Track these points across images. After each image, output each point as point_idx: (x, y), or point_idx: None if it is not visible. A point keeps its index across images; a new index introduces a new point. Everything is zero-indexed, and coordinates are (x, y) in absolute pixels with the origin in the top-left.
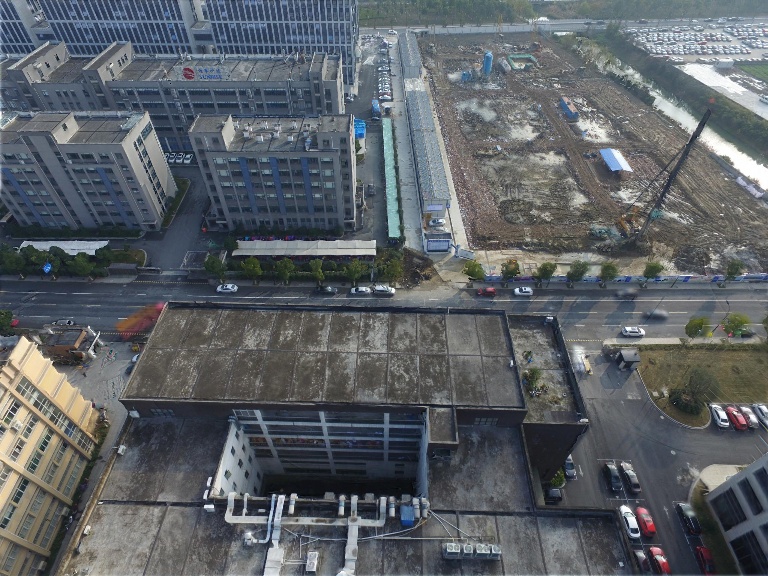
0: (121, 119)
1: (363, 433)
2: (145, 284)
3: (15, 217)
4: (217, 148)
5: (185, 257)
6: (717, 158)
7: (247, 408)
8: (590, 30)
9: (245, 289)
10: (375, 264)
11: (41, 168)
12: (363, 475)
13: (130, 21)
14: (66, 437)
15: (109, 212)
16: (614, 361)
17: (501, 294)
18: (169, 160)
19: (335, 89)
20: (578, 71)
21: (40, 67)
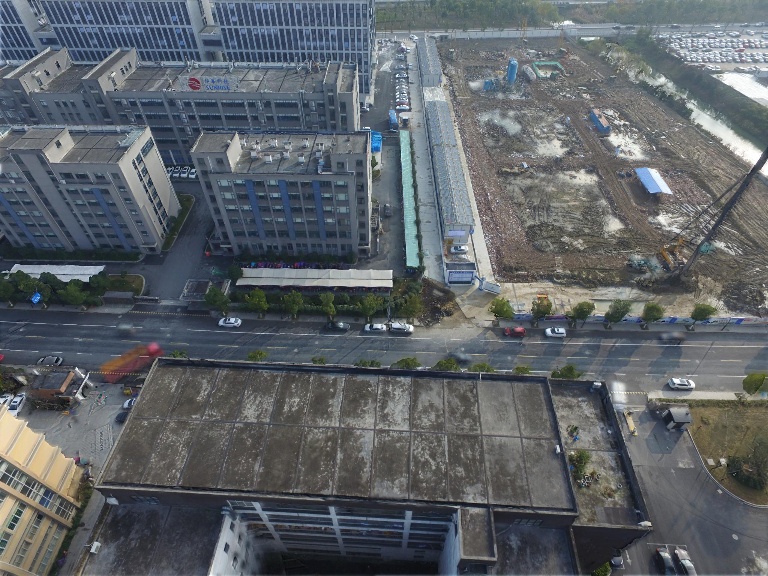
0: (120, 134)
1: (379, 525)
2: (142, 315)
3: (7, 237)
4: (221, 169)
5: (185, 286)
6: (765, 179)
7: (244, 500)
8: (620, 36)
9: (249, 323)
10: (391, 296)
11: (33, 188)
12: (377, 557)
13: (136, 25)
14: (41, 508)
15: (106, 234)
16: (661, 419)
17: (531, 335)
18: (173, 174)
19: (351, 101)
20: (608, 80)
21: (39, 75)
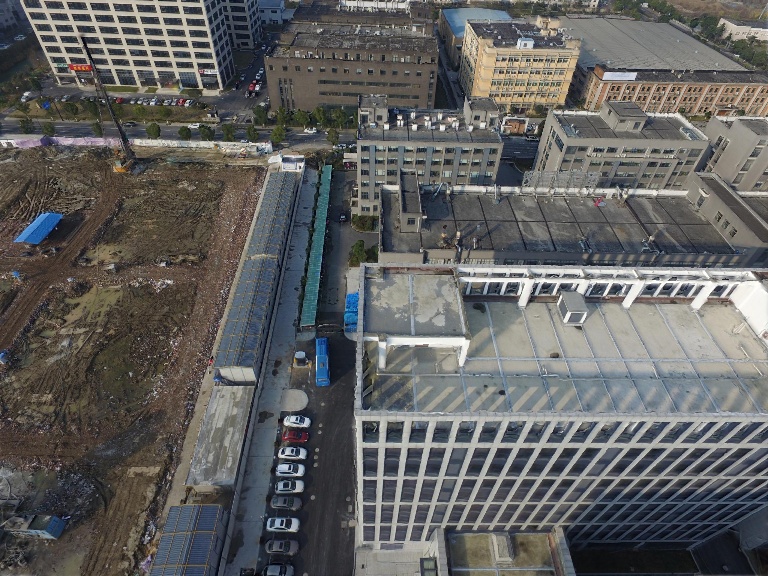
0: None
1: None
2: None
3: None
4: None
5: None
6: None
7: None
8: None
9: None
10: None
11: None
12: None
13: None
14: None
15: None
16: None
17: None
18: None
19: None
20: None
21: None
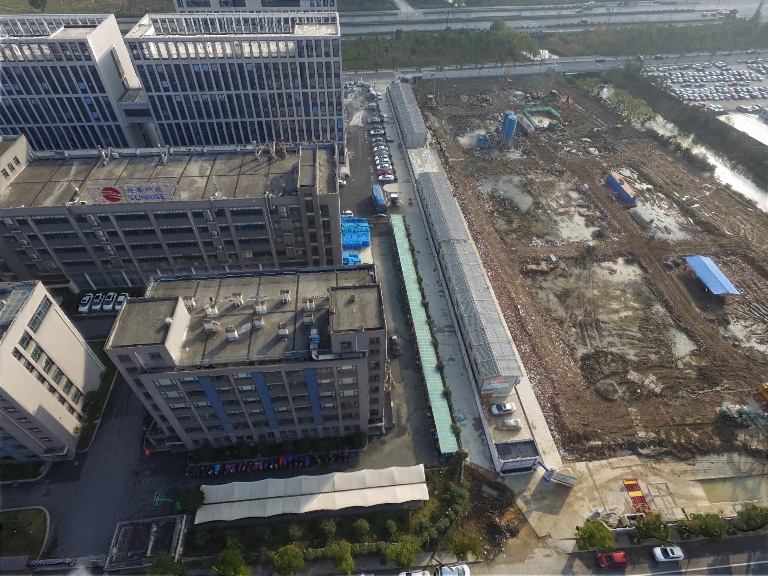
0: None
1: None
2: None
3: None
4: (159, 364)
5: (113, 538)
6: None
7: None
8: None
9: None
10: (427, 508)
11: None
12: None
13: (28, 96)
14: None
15: None
16: None
17: (634, 560)
18: (92, 307)
19: (335, 204)
20: (613, 130)
21: None
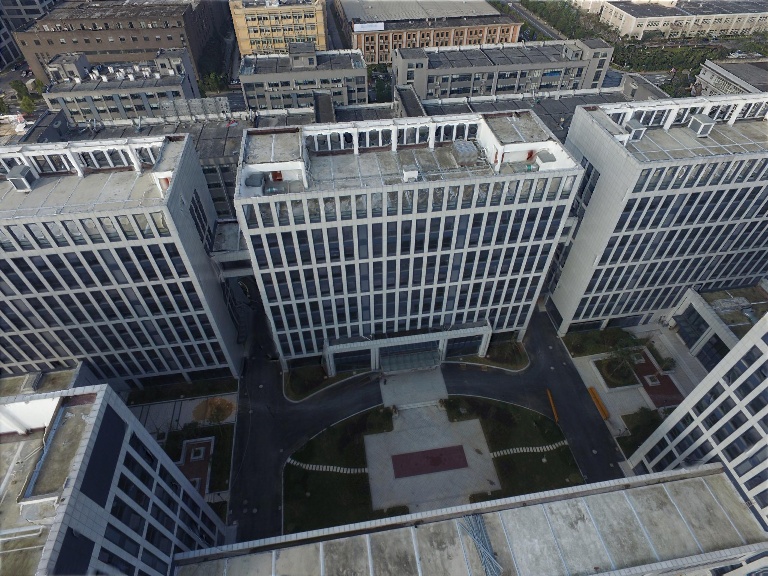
0: None
1: None
2: None
3: None
4: None
5: None
6: None
7: None
8: None
9: None
10: None
11: None
12: None
13: None
14: None
15: None
16: None
17: None
18: None
19: None
20: None
21: None
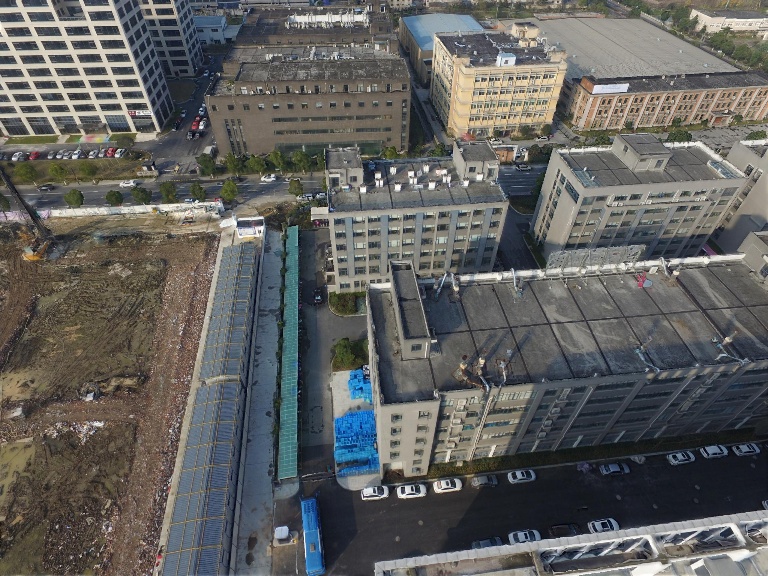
0: None
1: None
2: None
3: None
4: None
5: None
6: None
7: None
8: None
9: None
10: None
11: None
12: None
13: None
14: None
15: None
16: None
17: None
18: None
19: None
20: None
21: None
